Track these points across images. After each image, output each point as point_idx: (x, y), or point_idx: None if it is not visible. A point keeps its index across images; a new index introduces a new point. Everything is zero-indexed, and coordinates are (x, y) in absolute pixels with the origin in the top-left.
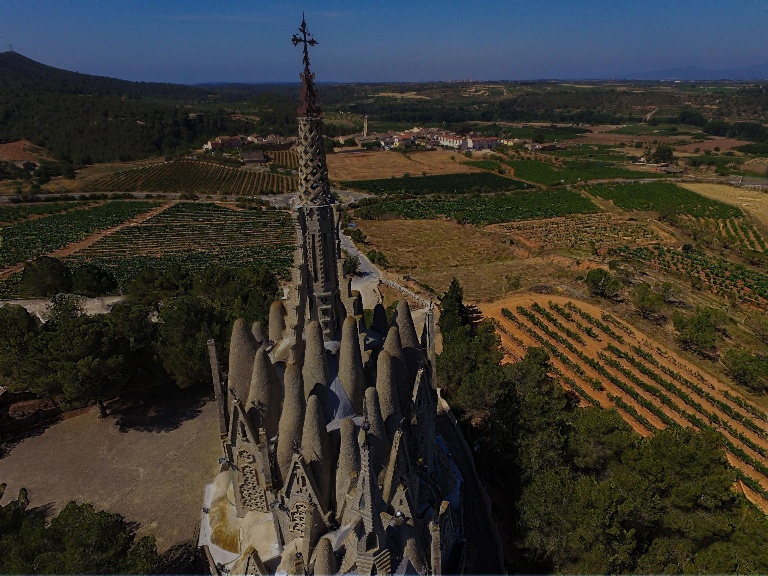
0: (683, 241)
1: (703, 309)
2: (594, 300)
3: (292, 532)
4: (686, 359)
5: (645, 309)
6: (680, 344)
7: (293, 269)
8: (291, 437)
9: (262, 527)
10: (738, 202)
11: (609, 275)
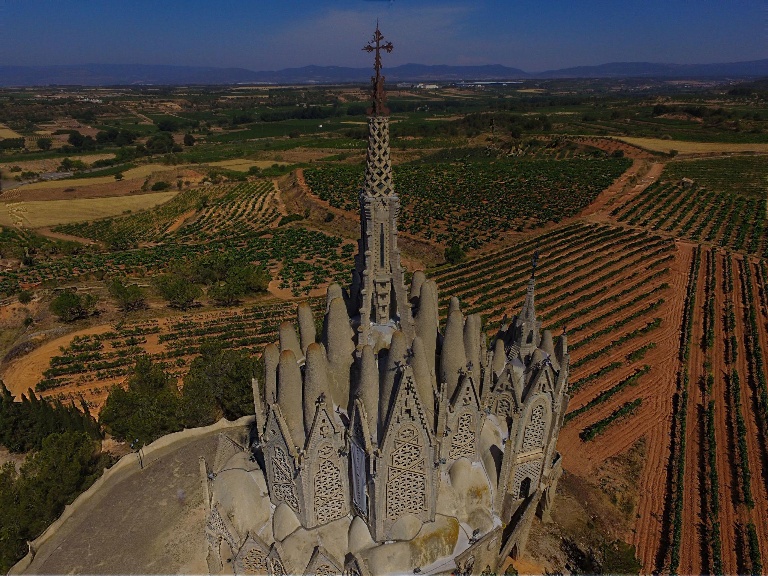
0: (1, 261)
1: (161, 279)
2: (82, 324)
3: None
4: (200, 312)
5: (134, 302)
6: (178, 309)
7: (368, 271)
8: None
9: (463, 472)
10: (8, 210)
11: (75, 295)
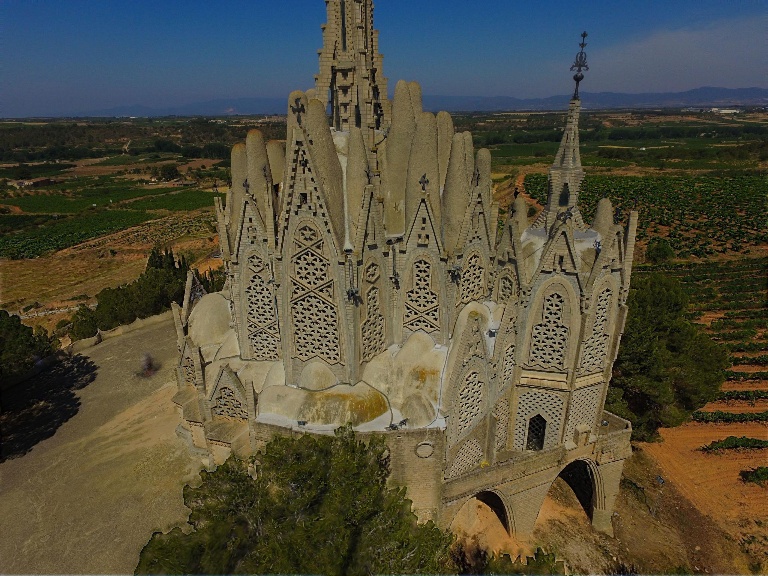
0: None
1: None
2: None
3: (458, 307)
4: None
5: None
6: None
7: None
8: (439, 196)
9: (412, 344)
10: None
11: None
